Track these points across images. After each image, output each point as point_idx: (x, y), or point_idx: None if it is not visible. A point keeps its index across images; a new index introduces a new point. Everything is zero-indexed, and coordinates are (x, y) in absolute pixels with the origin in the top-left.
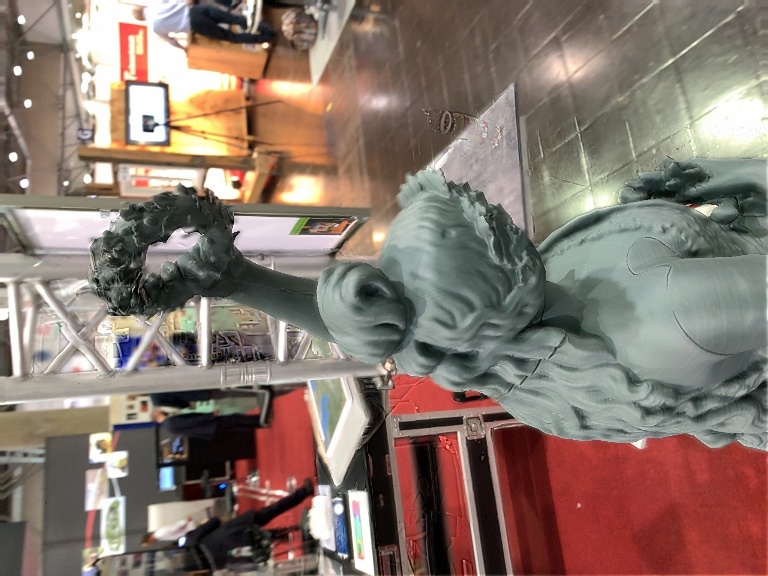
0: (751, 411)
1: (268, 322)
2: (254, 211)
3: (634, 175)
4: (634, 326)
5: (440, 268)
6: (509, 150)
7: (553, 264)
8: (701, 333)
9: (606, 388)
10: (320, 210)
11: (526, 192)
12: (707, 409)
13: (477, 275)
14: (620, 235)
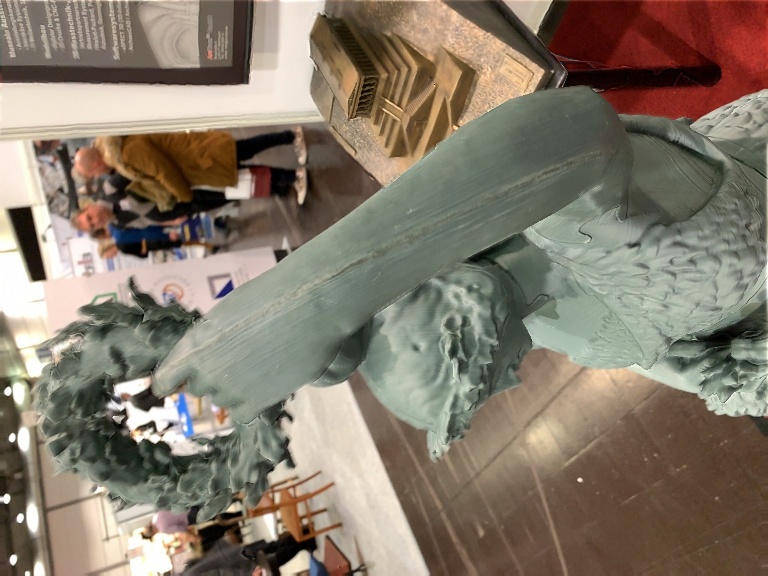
0: None
1: None
2: None
3: None
4: None
5: None
6: None
7: (591, 310)
8: None
9: None
10: None
11: None
12: None
13: None
14: None
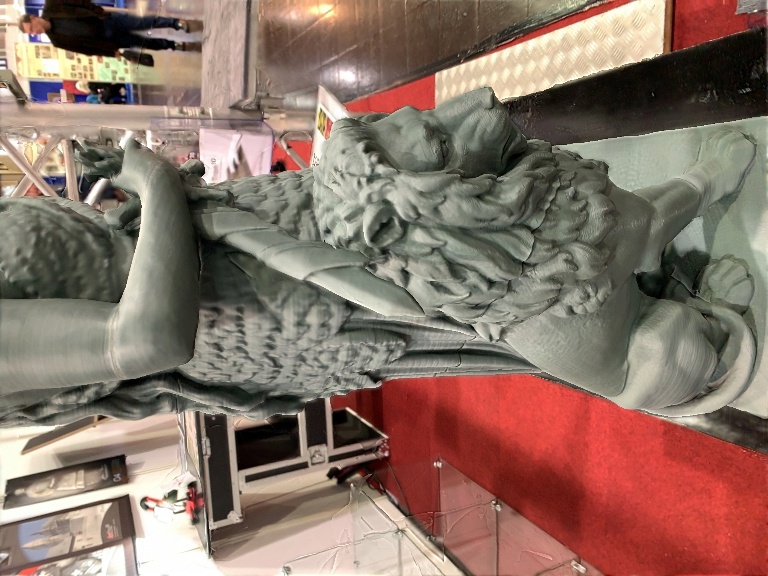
0: (102, 412)
1: None
2: None
3: None
4: None
5: None
6: None
7: None
8: None
9: None
10: None
11: (251, 42)
12: (48, 414)
13: None
14: None
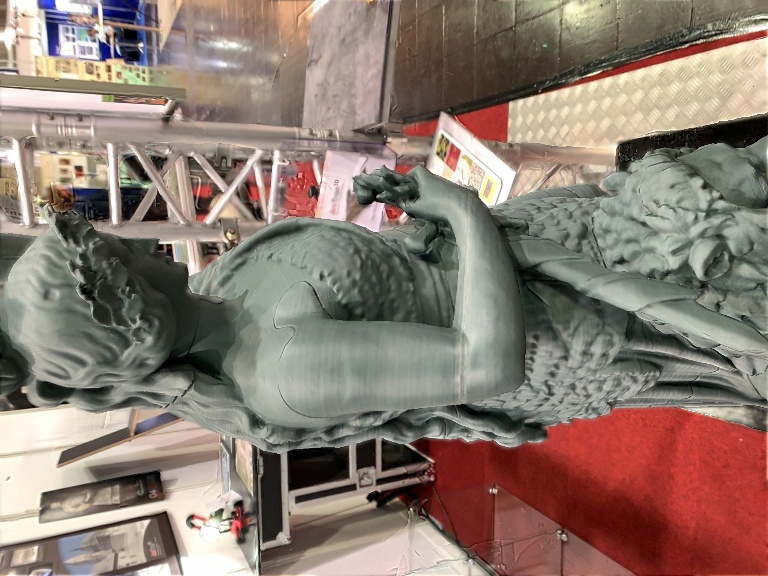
0: (388, 435)
1: (108, 175)
2: (40, 85)
3: (557, 24)
4: (253, 384)
5: (41, 330)
6: (381, 11)
7: (246, 270)
8: (300, 406)
9: (236, 424)
10: (123, 88)
11: (388, 68)
12: (342, 436)
13: (84, 337)
14: (289, 269)
